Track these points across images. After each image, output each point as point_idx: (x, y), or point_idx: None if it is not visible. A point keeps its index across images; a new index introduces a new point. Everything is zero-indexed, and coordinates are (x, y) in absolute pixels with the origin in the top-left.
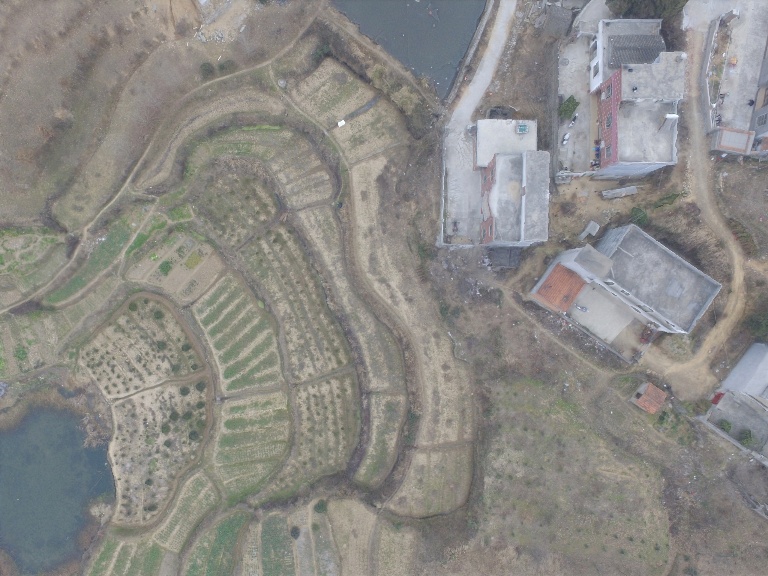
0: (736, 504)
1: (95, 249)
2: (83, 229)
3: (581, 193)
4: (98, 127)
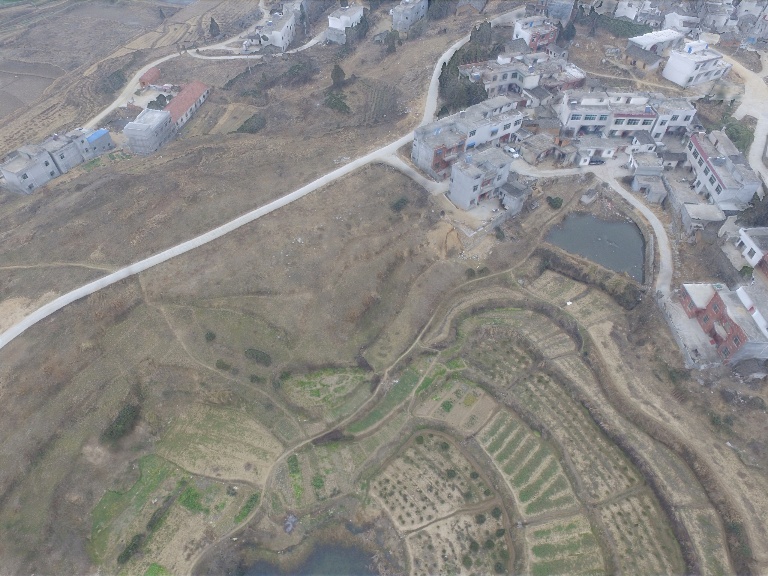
0: None
1: (390, 389)
2: (385, 371)
3: None
4: (397, 304)
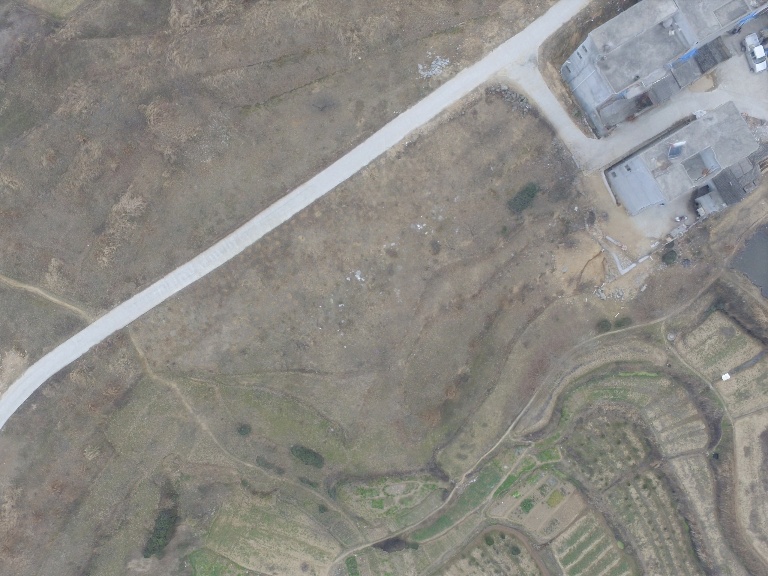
0: None
1: (465, 489)
2: (463, 475)
3: None
4: (491, 380)
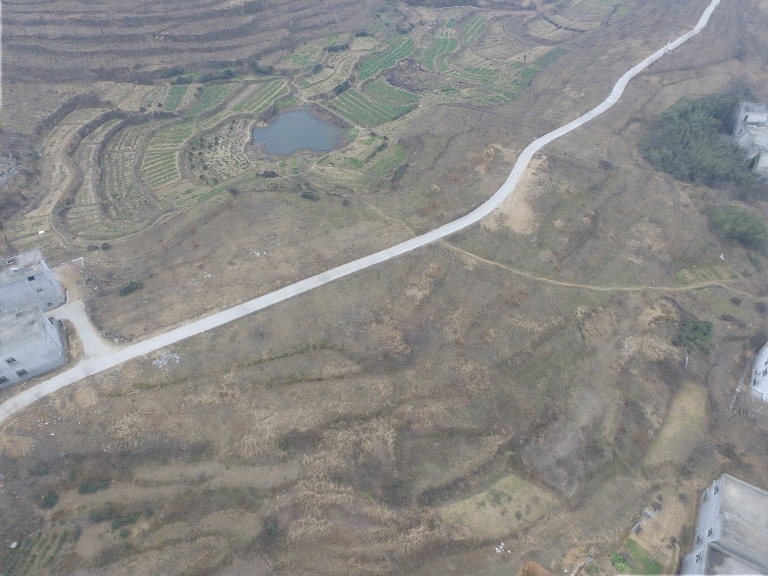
0: None
1: None
2: None
3: None
4: None
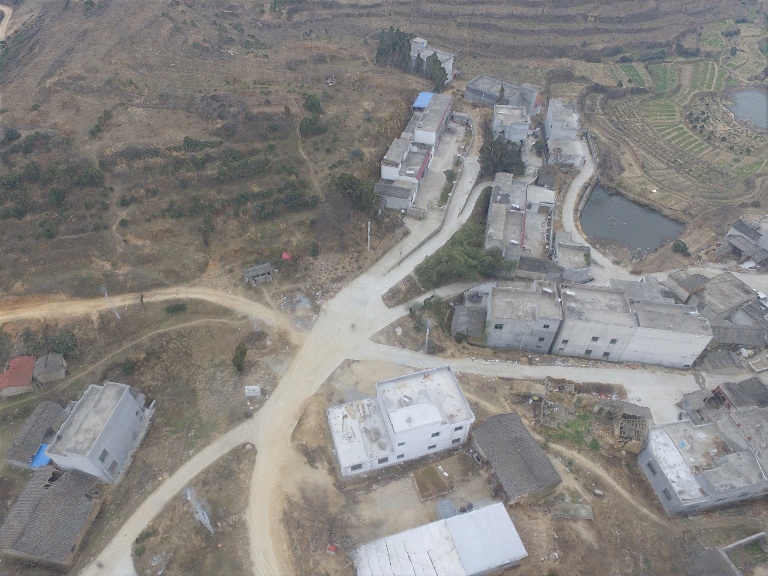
0: None
1: None
2: None
3: None
4: None
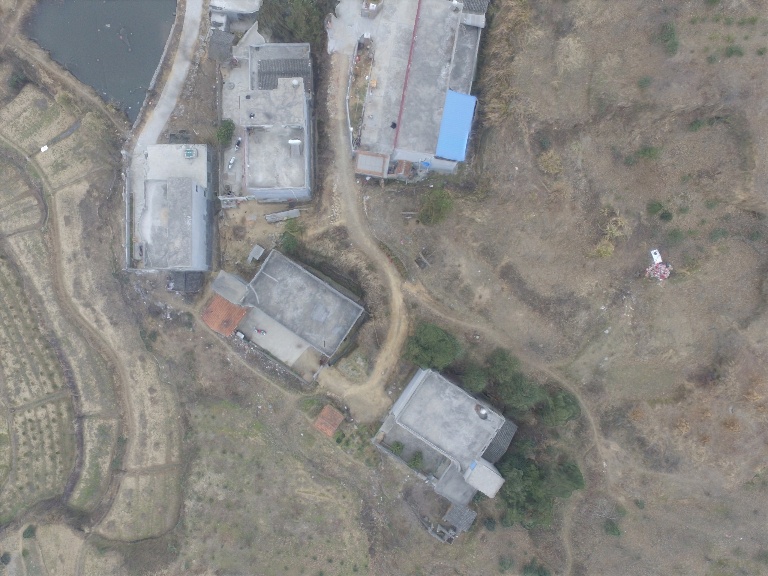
0: (412, 526)
1: None
2: None
3: (250, 217)
4: None
